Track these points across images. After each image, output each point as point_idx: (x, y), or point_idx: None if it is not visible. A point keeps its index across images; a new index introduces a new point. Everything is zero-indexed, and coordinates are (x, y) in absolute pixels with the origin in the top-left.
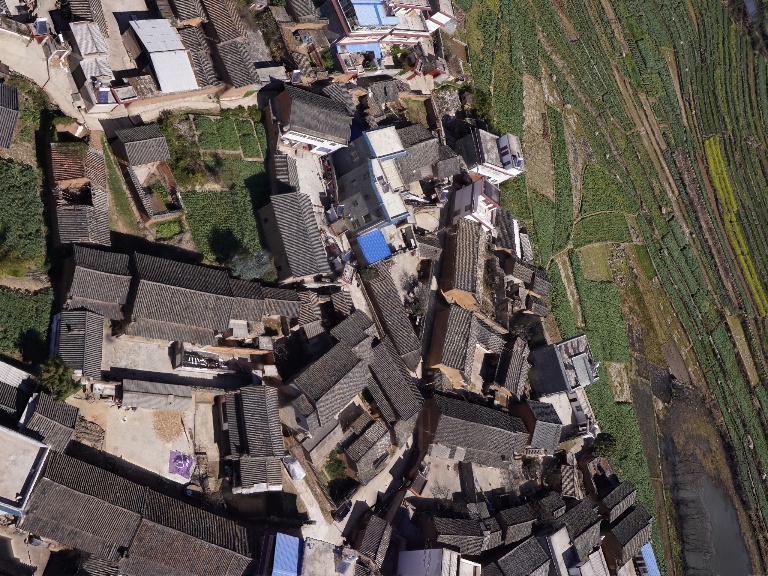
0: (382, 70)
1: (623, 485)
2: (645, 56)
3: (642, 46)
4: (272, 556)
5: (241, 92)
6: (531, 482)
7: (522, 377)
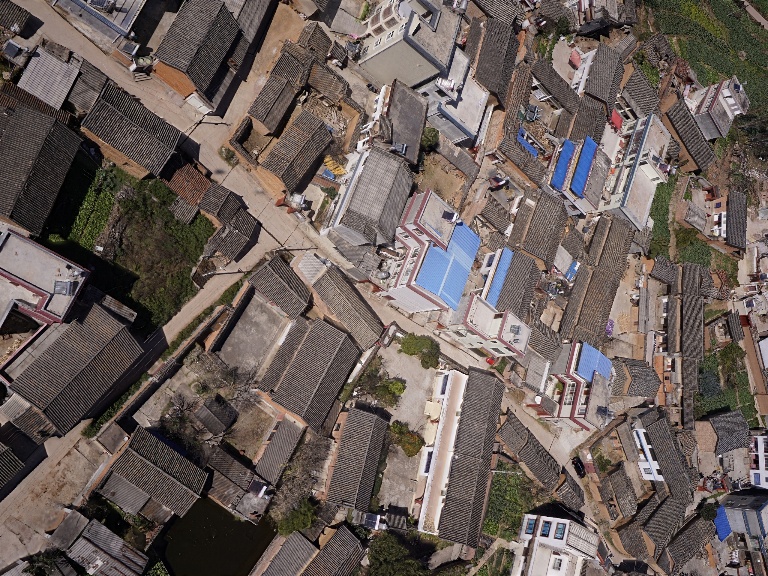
0: None
1: None
2: None
3: None
4: None
5: (765, 410)
6: None
7: None
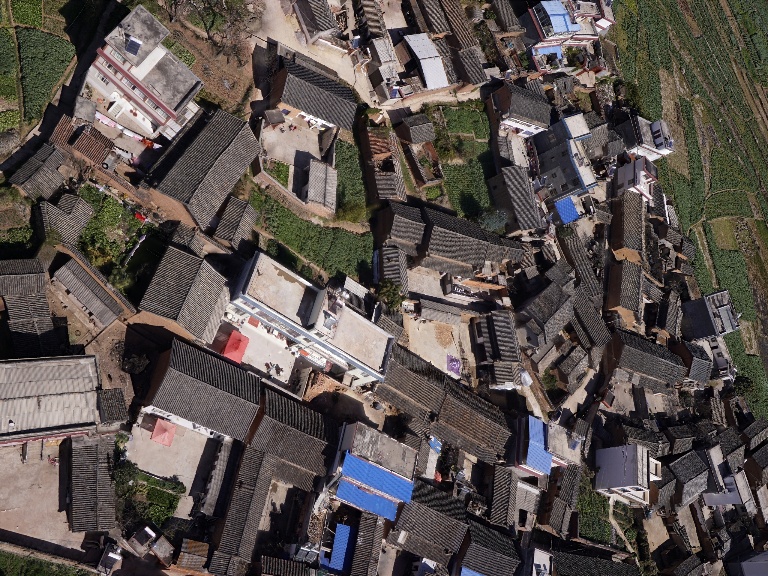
0: (562, 68)
1: (759, 421)
2: (759, 49)
3: (756, 40)
4: (527, 431)
5: (471, 88)
6: (686, 410)
7: (678, 323)
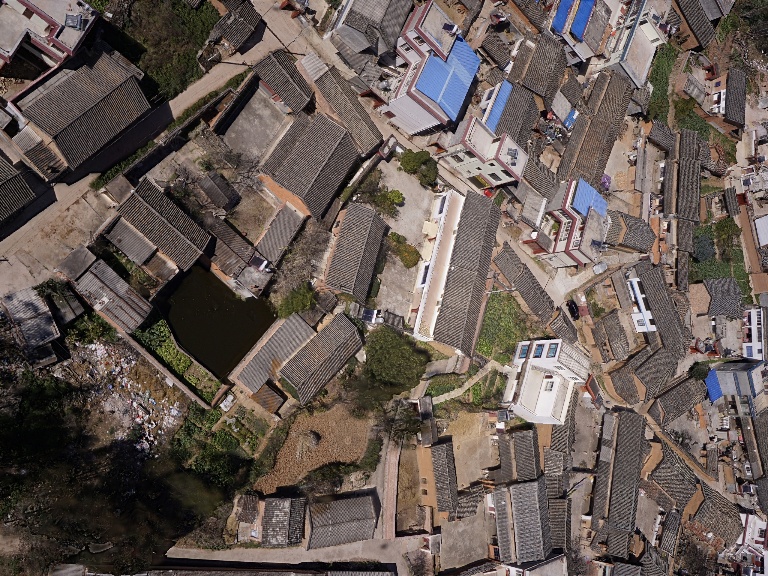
0: None
1: None
2: None
3: None
4: None
5: (759, 288)
6: None
7: (654, 573)
